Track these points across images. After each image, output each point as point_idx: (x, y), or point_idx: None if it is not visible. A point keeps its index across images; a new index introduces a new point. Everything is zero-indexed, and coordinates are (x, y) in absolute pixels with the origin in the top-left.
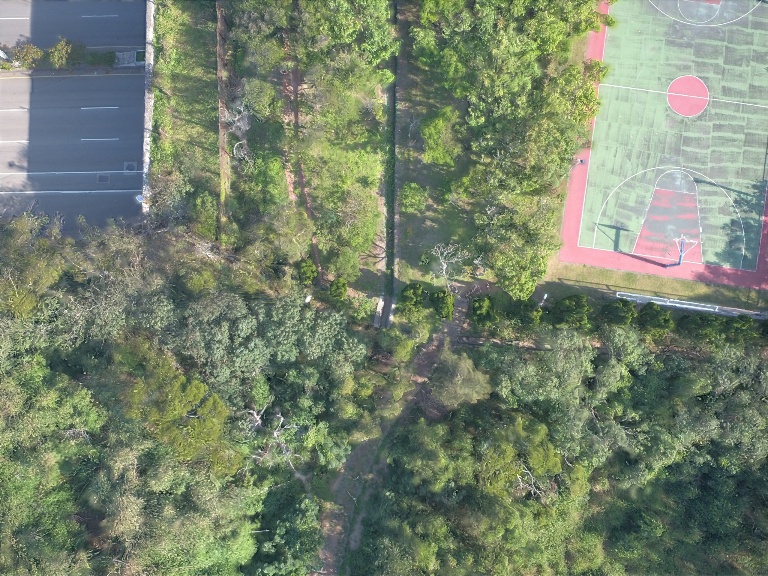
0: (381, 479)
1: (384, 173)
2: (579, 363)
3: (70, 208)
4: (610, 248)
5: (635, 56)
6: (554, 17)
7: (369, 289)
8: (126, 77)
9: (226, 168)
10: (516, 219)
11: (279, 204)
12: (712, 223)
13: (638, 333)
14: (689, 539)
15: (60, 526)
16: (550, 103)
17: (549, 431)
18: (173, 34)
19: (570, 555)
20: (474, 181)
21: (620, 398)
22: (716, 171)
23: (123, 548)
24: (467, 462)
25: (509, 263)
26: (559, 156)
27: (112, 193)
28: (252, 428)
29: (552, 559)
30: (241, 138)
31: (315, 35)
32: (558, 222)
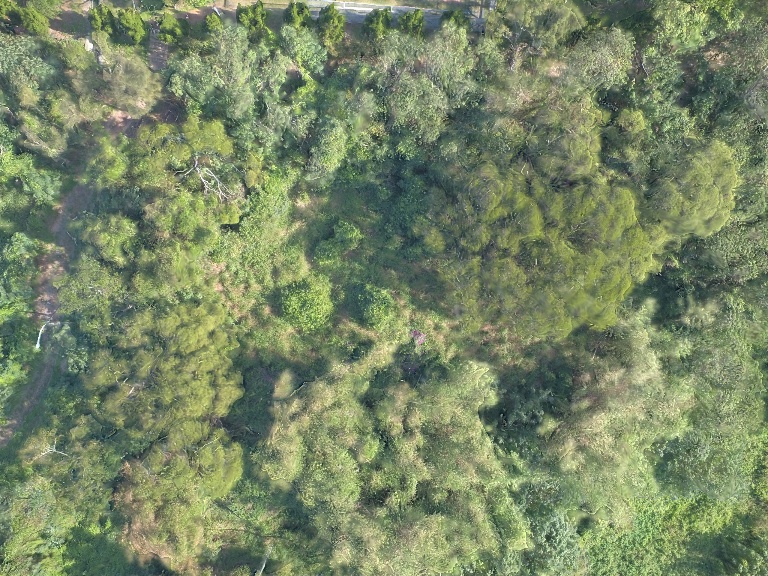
0: None
1: None
2: (241, 52)
3: None
4: None
5: None
6: None
7: (74, 30)
8: None
9: None
10: None
11: None
12: None
13: (316, 37)
14: (388, 245)
15: None
16: None
17: (225, 129)
18: None
19: (277, 271)
20: None
21: None
22: None
23: None
24: None
25: None
26: None
27: None
28: None
29: (258, 275)
30: None
31: None
32: None
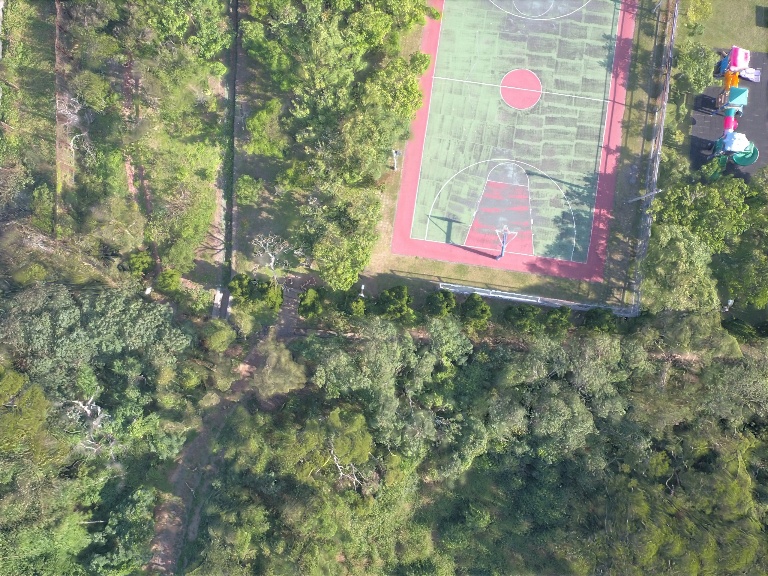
0: (218, 470)
1: (223, 165)
2: (391, 353)
3: None
4: (442, 240)
5: (469, 49)
6: (380, 10)
7: (206, 281)
8: None
9: (68, 160)
10: None
11: (116, 196)
12: (543, 215)
13: (460, 324)
14: (517, 530)
15: None
16: (368, 95)
17: (366, 421)
18: (21, 28)
19: (401, 546)
20: (298, 172)
21: (442, 389)
22: (548, 164)
23: None
24: (287, 452)
25: (329, 254)
26: (374, 147)
27: None
28: (82, 419)
29: (382, 550)
30: (82, 131)
31: (145, 28)
32: (391, 214)
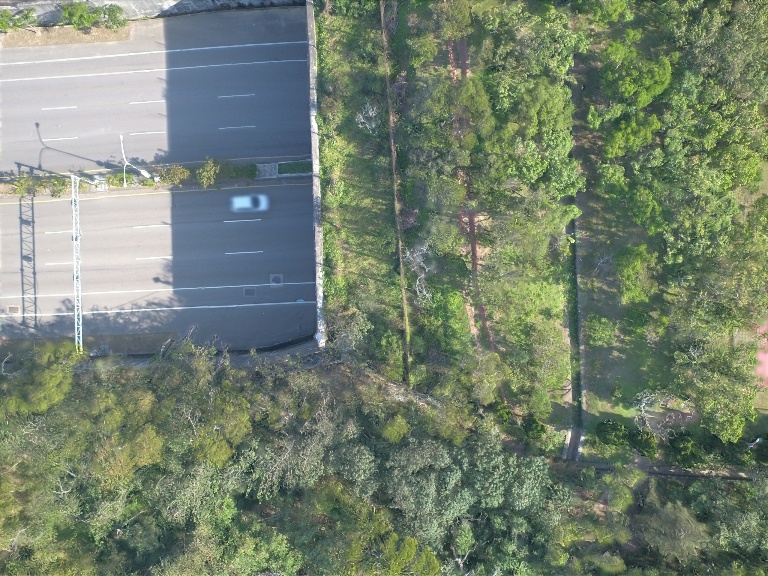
0: None
1: (567, 304)
2: None
3: (218, 323)
4: None
5: None
6: (749, 148)
7: (557, 422)
8: (267, 188)
9: None
10: (707, 348)
11: (464, 341)
12: None
13: None
14: None
15: None
16: (756, 244)
17: (765, 575)
18: (339, 165)
19: None
20: (674, 321)
21: None
22: None
23: None
24: None
25: (717, 406)
26: None
27: (259, 306)
28: (453, 571)
29: None
30: (419, 273)
31: (502, 175)
32: None
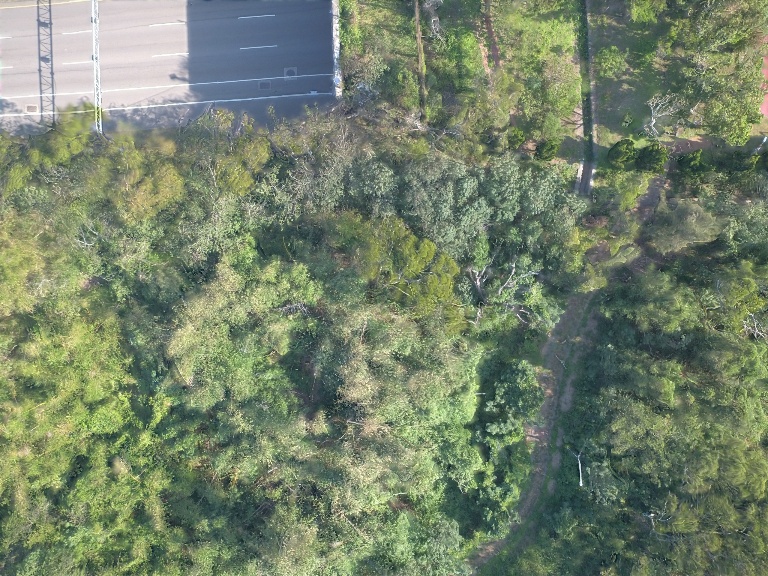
0: (589, 341)
1: (578, 41)
2: None
3: None
4: None
5: None
6: None
7: (570, 155)
8: None
9: None
10: None
11: (478, 76)
12: None
13: None
14: None
15: (280, 401)
16: None
17: None
18: None
19: None
20: (683, 34)
21: None
22: None
23: (352, 412)
24: (692, 307)
25: (725, 110)
26: None
27: (274, 99)
28: (470, 291)
29: (767, 406)
30: (433, 16)
31: None
32: None
